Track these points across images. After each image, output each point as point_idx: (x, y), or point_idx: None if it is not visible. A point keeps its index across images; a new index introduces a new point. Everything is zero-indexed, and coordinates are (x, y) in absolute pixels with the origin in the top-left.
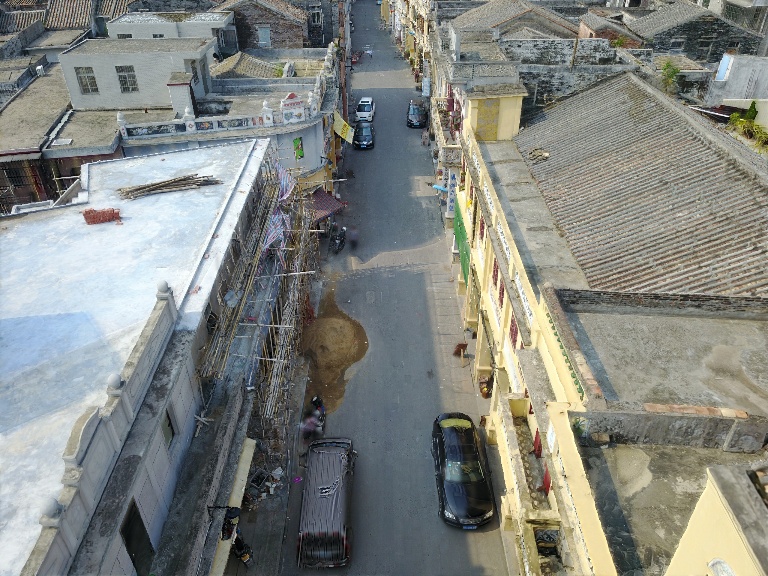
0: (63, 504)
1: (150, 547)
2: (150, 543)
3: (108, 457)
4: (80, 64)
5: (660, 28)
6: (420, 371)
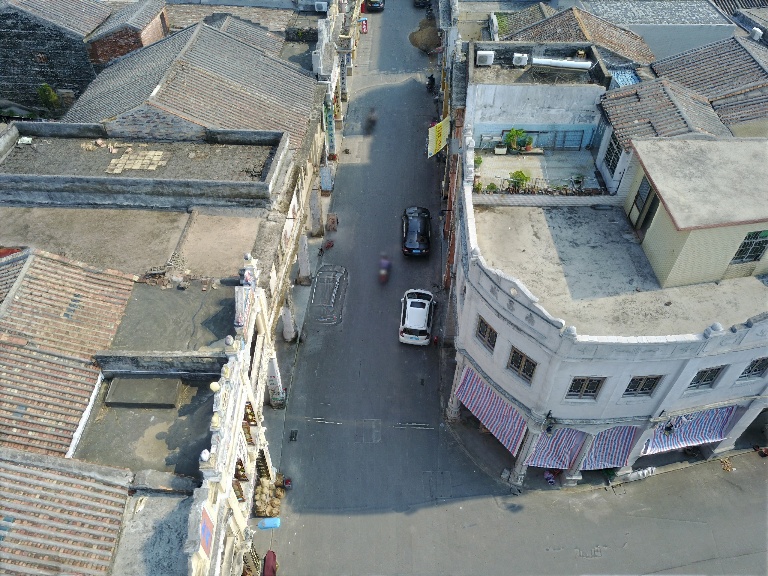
0: None
1: None
2: None
3: None
4: None
5: (93, 1)
6: (385, 28)
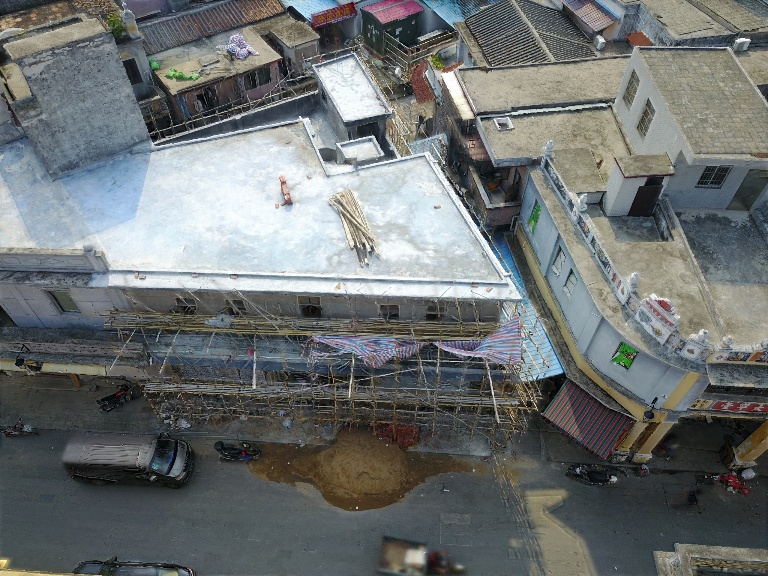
0: None
1: (12, 321)
2: (12, 320)
3: None
4: (638, 70)
5: None
6: (296, 571)
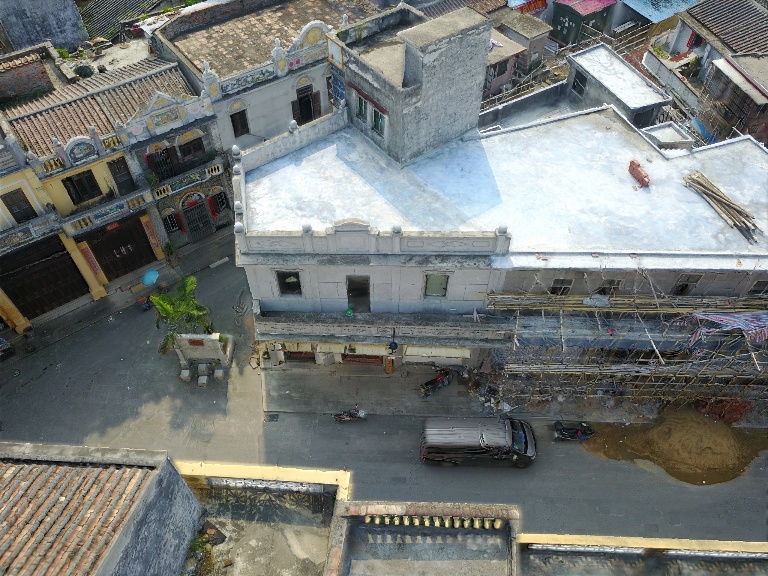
0: (315, 233)
1: (369, 307)
2: (370, 306)
3: (362, 248)
4: None
5: None
6: None
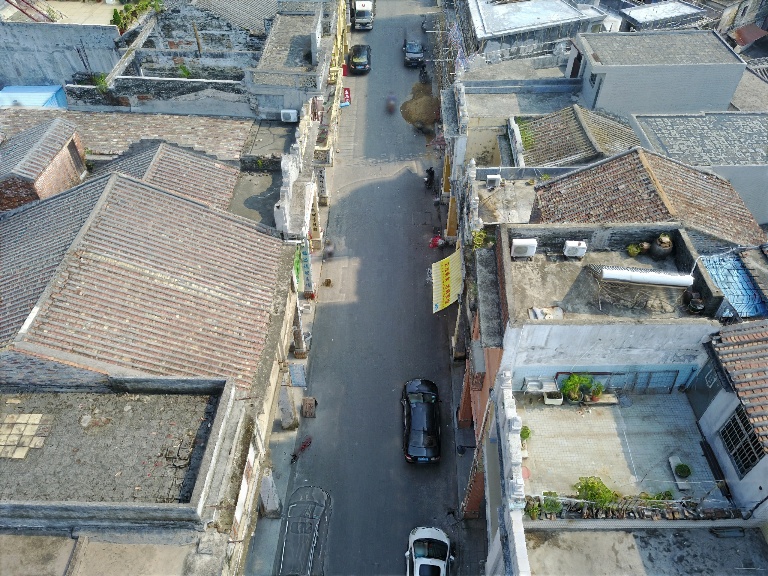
0: None
1: None
2: None
3: None
4: None
5: None
6: (371, 97)
